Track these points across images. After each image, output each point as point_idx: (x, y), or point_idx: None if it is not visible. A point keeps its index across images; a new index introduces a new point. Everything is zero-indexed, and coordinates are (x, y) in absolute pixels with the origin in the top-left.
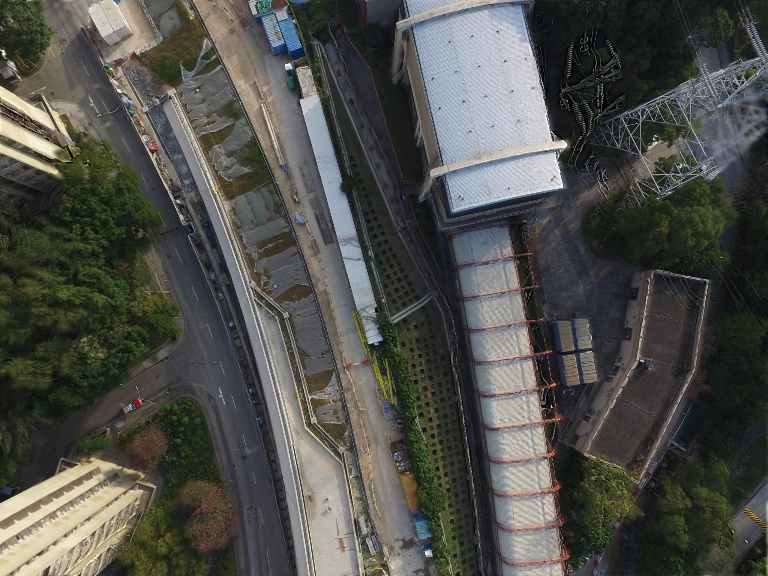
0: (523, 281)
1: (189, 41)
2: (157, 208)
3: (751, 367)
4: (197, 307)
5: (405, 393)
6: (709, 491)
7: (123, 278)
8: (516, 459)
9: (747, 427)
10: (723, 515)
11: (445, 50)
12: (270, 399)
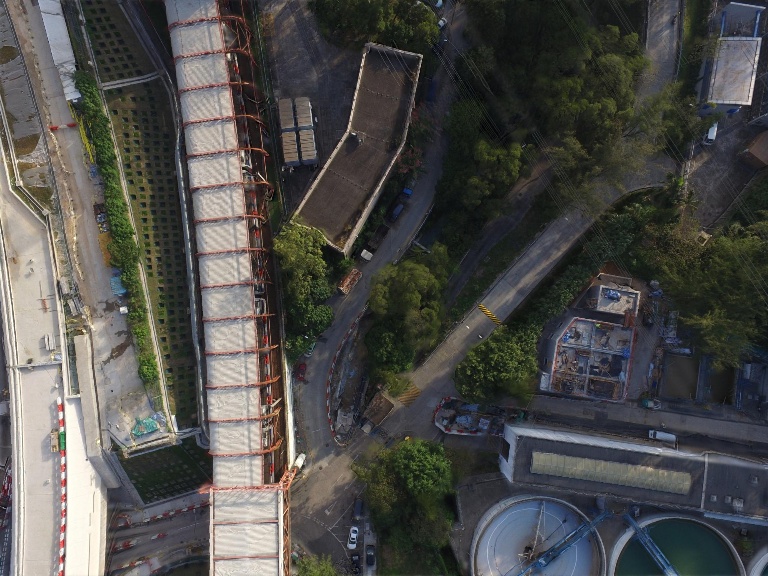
0: (229, 44)
1: None
2: None
3: (471, 150)
4: None
5: (100, 148)
6: (416, 264)
7: None
8: (212, 218)
9: (477, 219)
10: (418, 279)
11: None
12: None
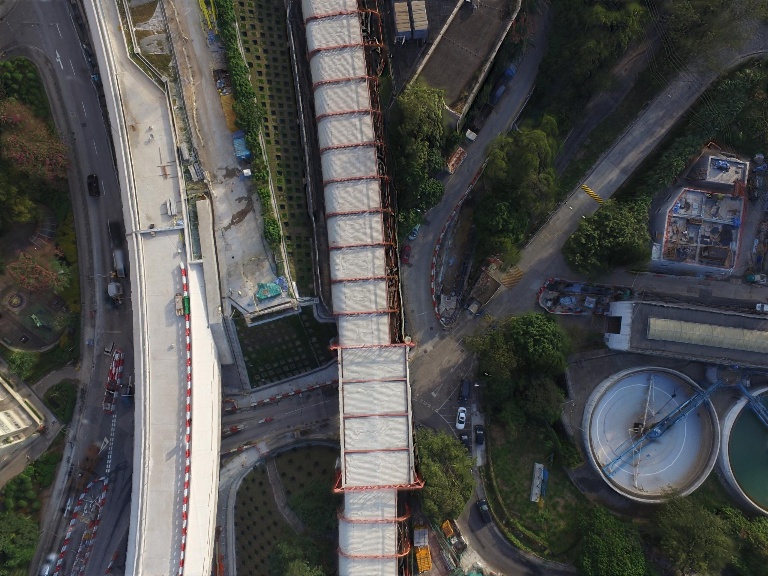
0: None
1: None
2: None
3: (581, 21)
4: None
5: (223, 9)
6: None
7: None
8: (334, 79)
9: (582, 95)
10: (538, 139)
11: None
12: (95, 34)
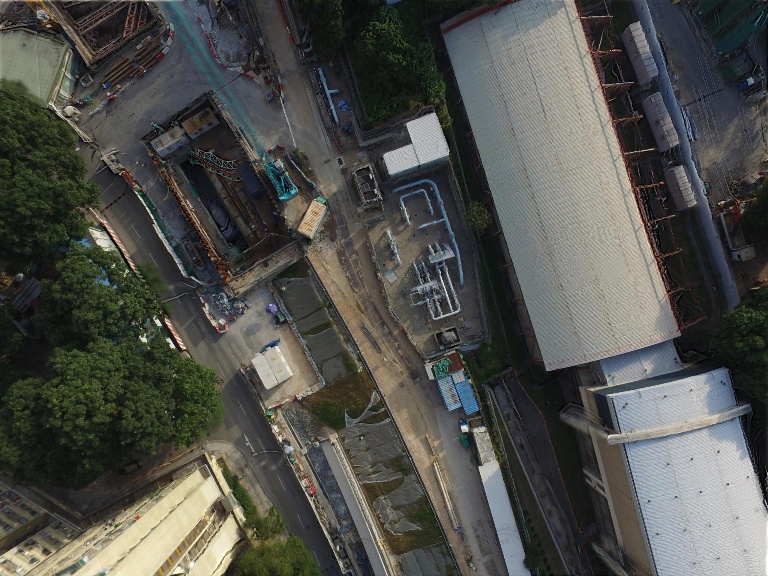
0: None
1: (356, 392)
2: None
3: None
4: None
5: None
6: None
7: None
8: None
9: None
10: None
11: (663, 473)
12: None
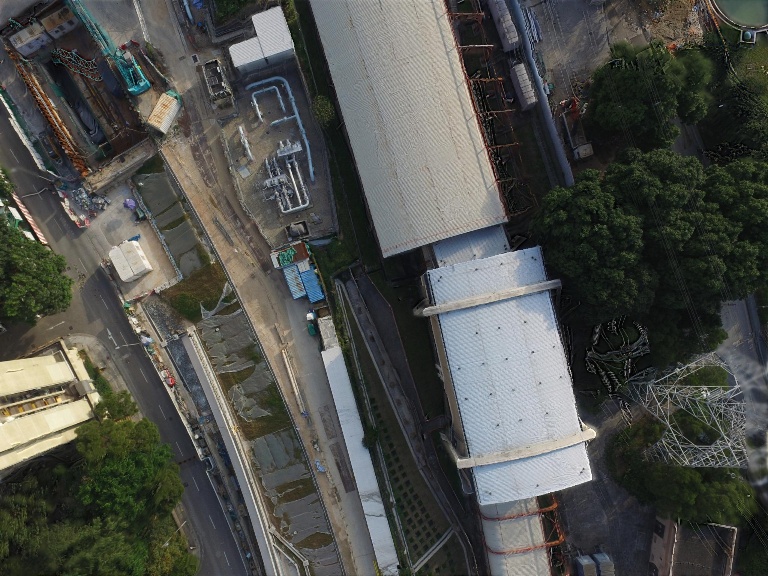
0: (548, 535)
1: (209, 284)
2: (175, 438)
3: None
4: (214, 535)
5: None
6: None
7: (142, 545)
8: None
9: None
10: None
11: (472, 341)
12: None
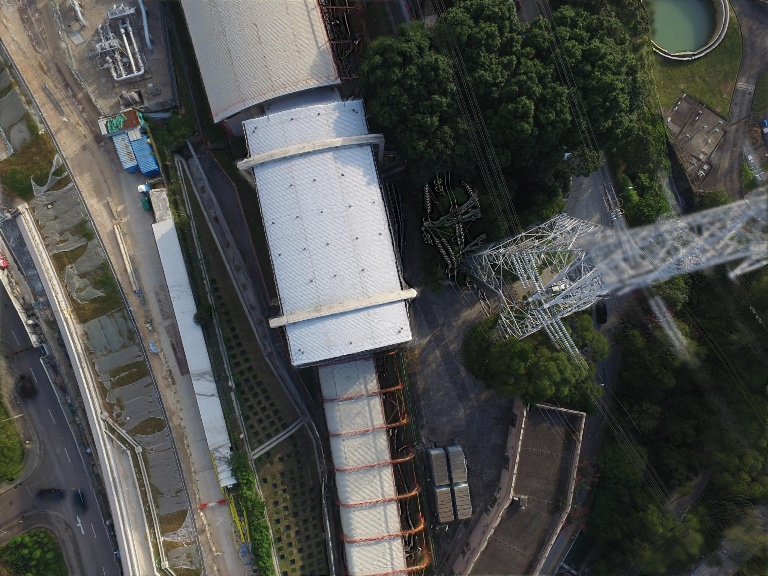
0: (389, 417)
1: (39, 156)
2: (10, 326)
3: (633, 500)
4: (54, 430)
5: (258, 541)
6: None
7: None
8: None
9: None
10: None
11: (286, 194)
12: (120, 539)
